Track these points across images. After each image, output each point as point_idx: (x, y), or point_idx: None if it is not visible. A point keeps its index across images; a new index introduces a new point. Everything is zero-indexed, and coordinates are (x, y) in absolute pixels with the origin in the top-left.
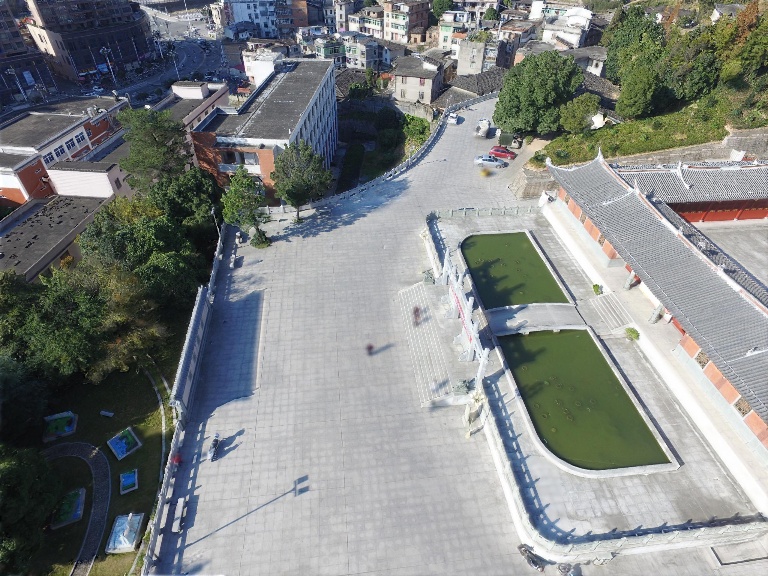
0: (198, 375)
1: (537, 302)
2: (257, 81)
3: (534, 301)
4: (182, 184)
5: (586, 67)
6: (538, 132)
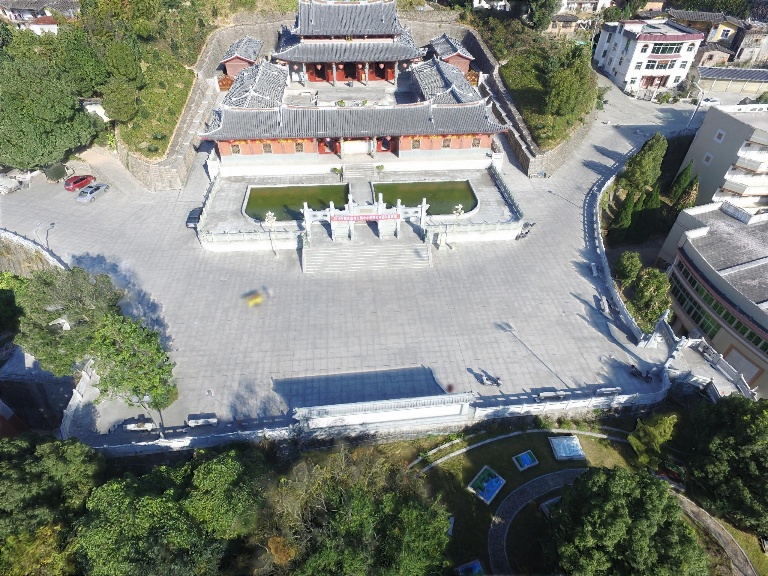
0: None
1: (342, 197)
2: None
3: (340, 198)
4: None
5: None
6: (83, 144)
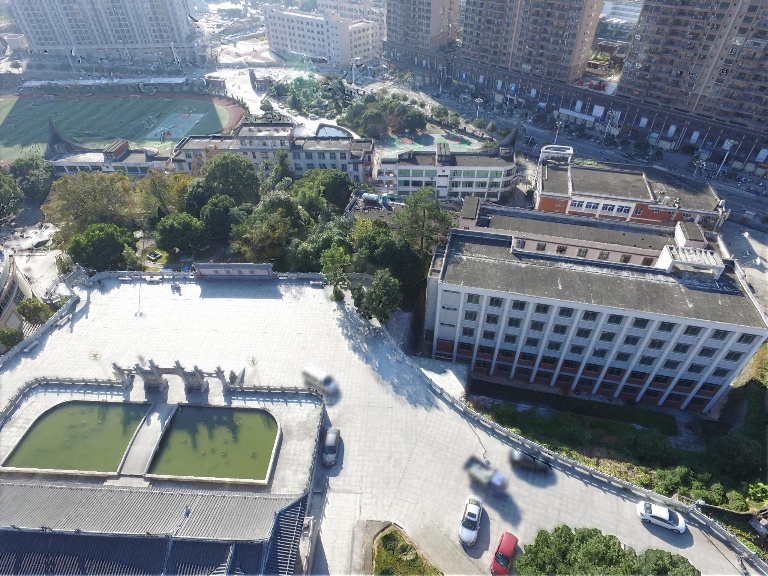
0: (224, 278)
1: (168, 449)
2: (656, 265)
3: (171, 447)
4: (374, 238)
5: None
6: None
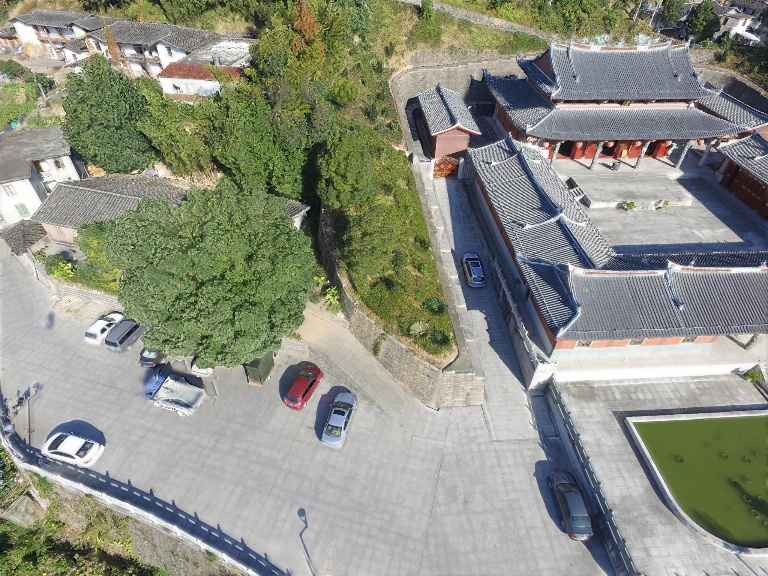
0: None
1: None
2: None
3: None
4: None
5: (39, 176)
6: None
